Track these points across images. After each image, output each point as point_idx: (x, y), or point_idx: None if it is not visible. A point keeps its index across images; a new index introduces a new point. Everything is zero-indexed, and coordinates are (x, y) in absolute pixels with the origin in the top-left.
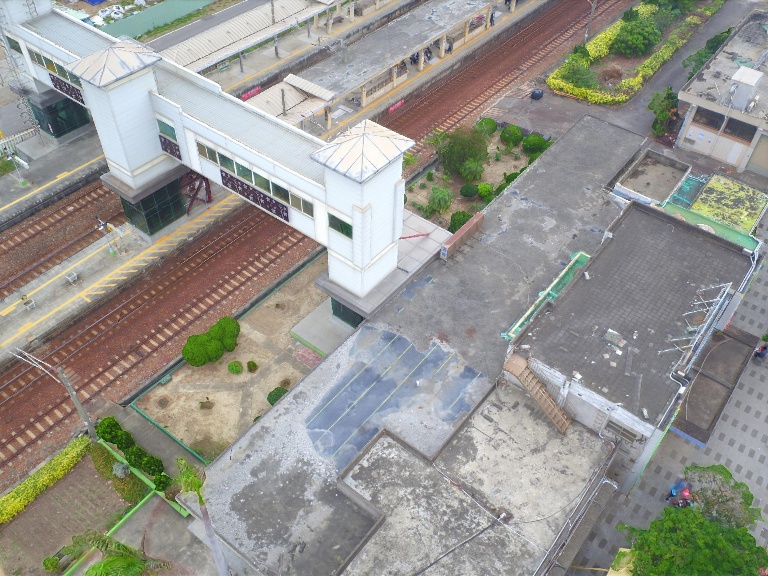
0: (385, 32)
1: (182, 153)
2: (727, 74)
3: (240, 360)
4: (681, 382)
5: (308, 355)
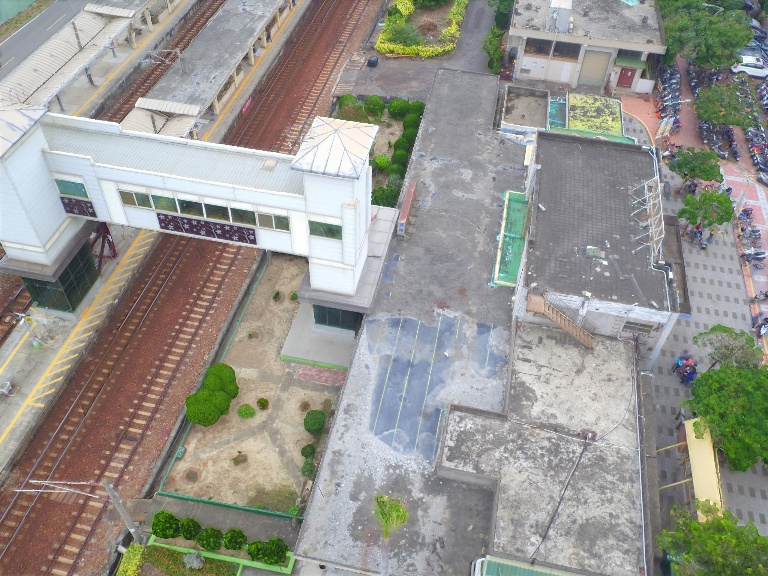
0: (209, 33)
1: (96, 209)
2: (535, 5)
3: (245, 402)
4: (663, 270)
5: (310, 372)
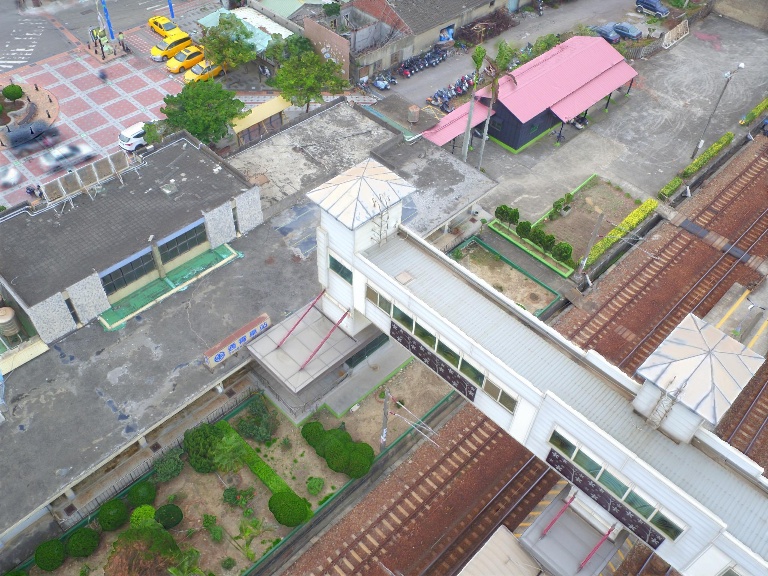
0: None
1: None
2: None
3: None
4: None
5: None
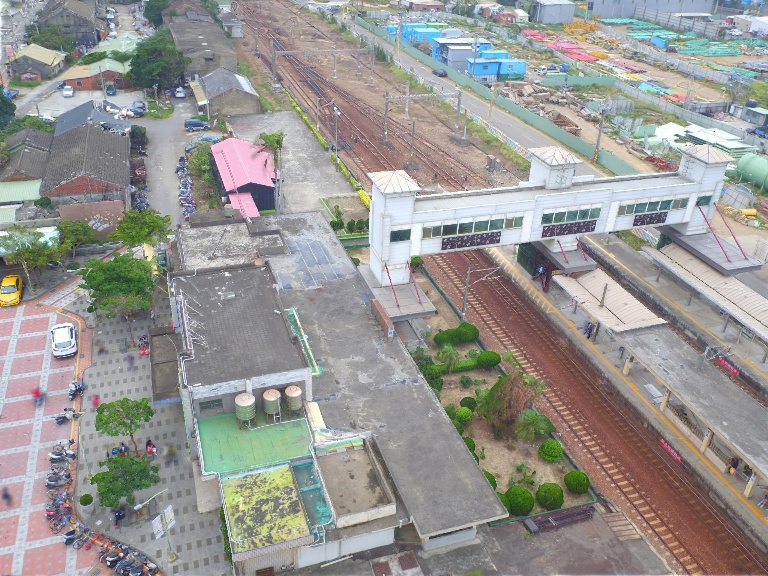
0: None
1: None
2: None
3: None
4: None
5: None
